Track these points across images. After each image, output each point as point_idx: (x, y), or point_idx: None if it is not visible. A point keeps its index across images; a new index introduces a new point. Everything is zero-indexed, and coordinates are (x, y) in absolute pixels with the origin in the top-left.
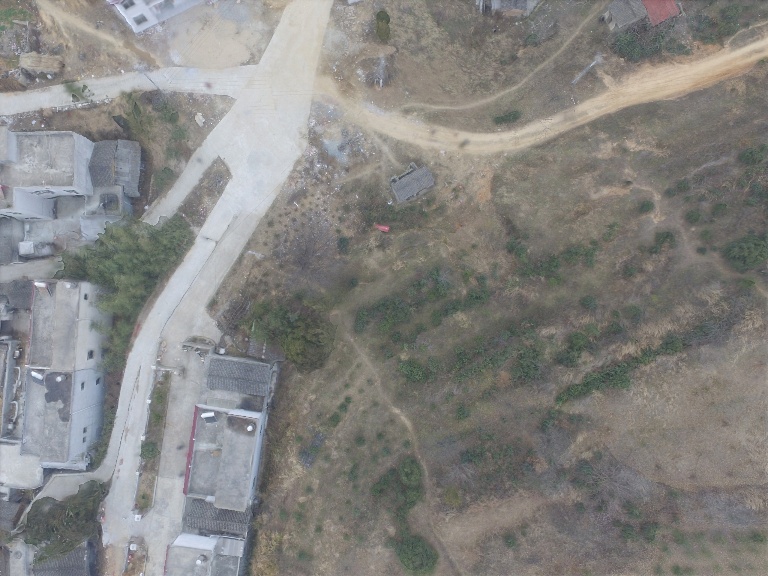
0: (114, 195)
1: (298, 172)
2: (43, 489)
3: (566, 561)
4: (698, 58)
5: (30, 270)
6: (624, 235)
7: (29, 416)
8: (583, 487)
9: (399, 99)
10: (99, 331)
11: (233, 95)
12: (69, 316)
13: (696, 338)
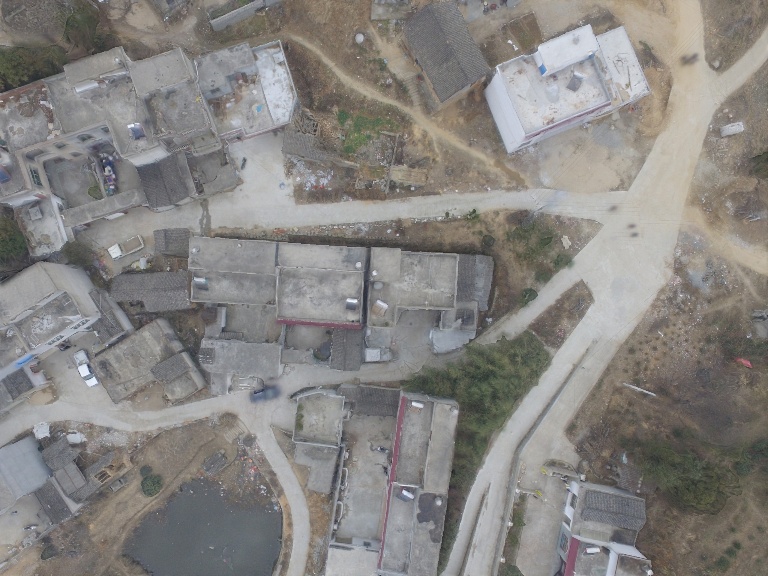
0: (471, 311)
1: (662, 301)
2: None
3: None
4: None
5: (362, 372)
6: None
7: (389, 531)
8: None
9: (763, 233)
10: (459, 449)
11: (600, 220)
12: (447, 438)
13: None
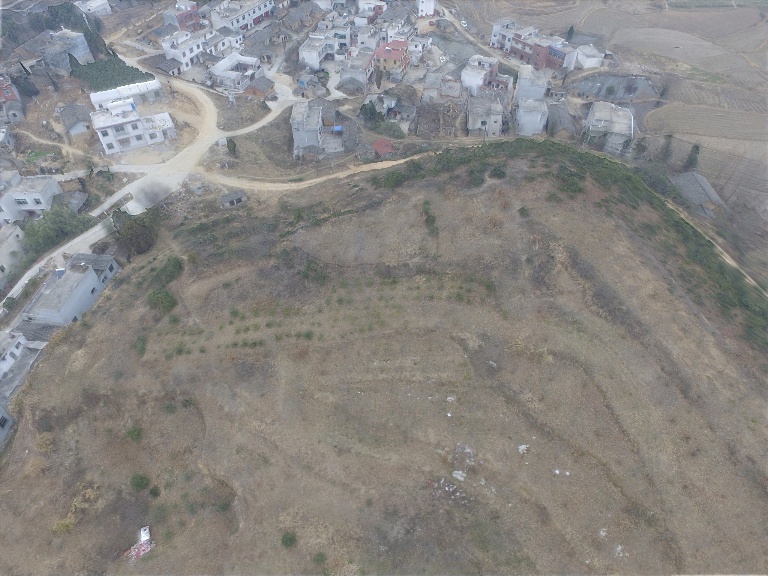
0: None
1: (171, 196)
2: None
3: (264, 298)
4: None
5: None
6: None
7: None
8: (280, 259)
9: (237, 174)
10: (16, 255)
11: (147, 172)
12: (2, 238)
13: None
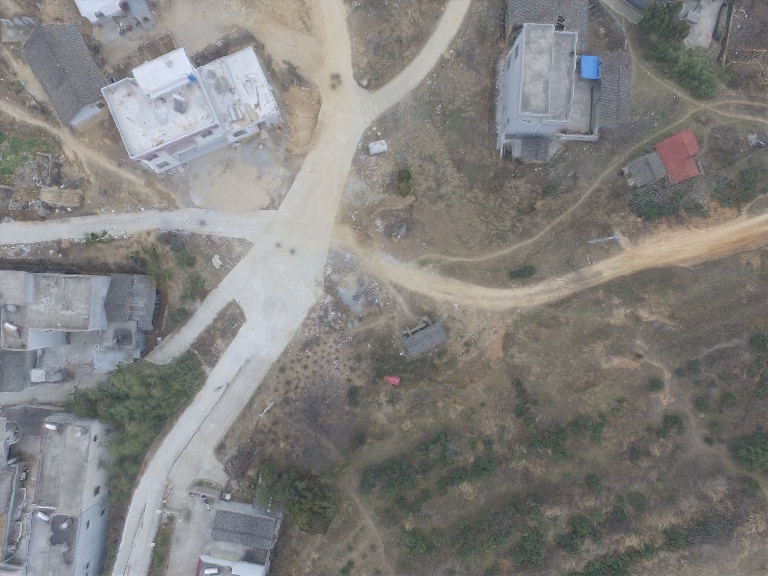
0: (128, 331)
1: (312, 319)
2: None
3: None
4: (715, 223)
5: (41, 392)
6: (633, 414)
7: (34, 552)
8: None
9: (416, 250)
10: (107, 469)
11: (251, 239)
12: (78, 460)
13: (700, 537)
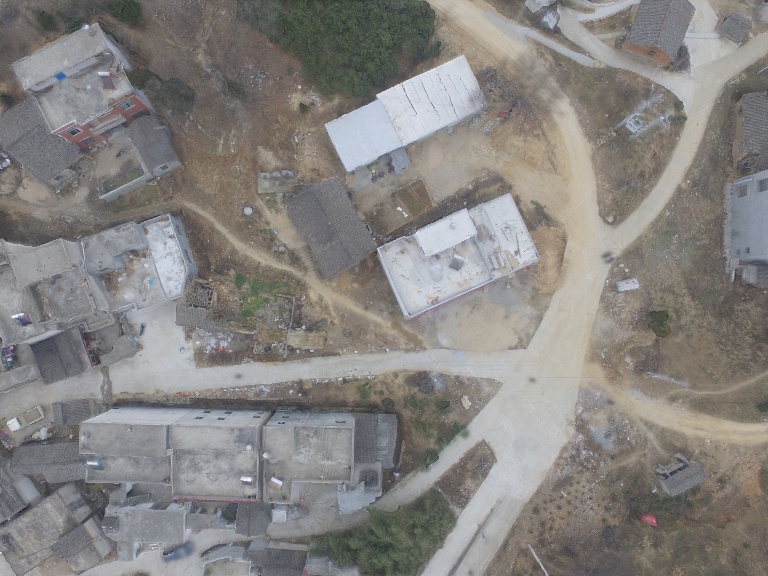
0: (374, 472)
1: (564, 459)
2: None
3: None
4: None
5: (273, 528)
6: None
7: None
8: None
9: (665, 386)
10: None
11: (500, 379)
12: None
13: None
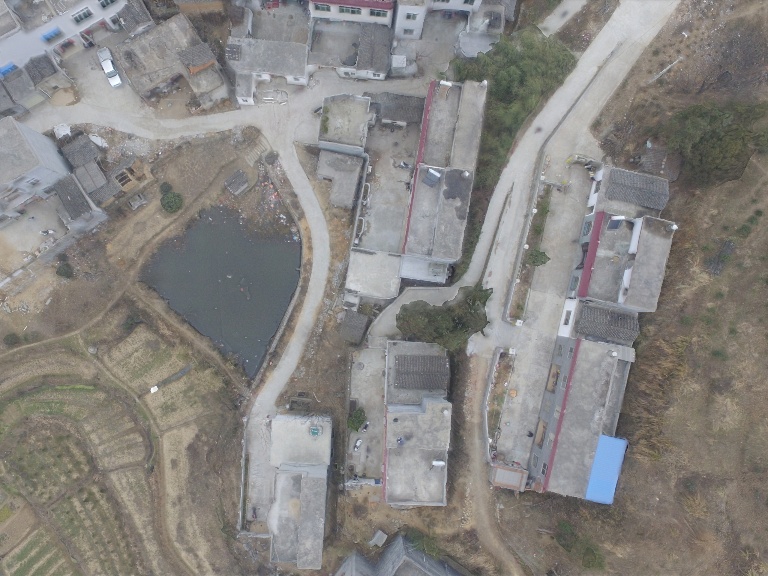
0: (498, 13)
1: (686, 5)
2: (394, 301)
3: None
4: None
5: (387, 89)
6: None
7: (414, 216)
8: None
9: None
10: (484, 141)
11: None
12: (474, 115)
13: None
